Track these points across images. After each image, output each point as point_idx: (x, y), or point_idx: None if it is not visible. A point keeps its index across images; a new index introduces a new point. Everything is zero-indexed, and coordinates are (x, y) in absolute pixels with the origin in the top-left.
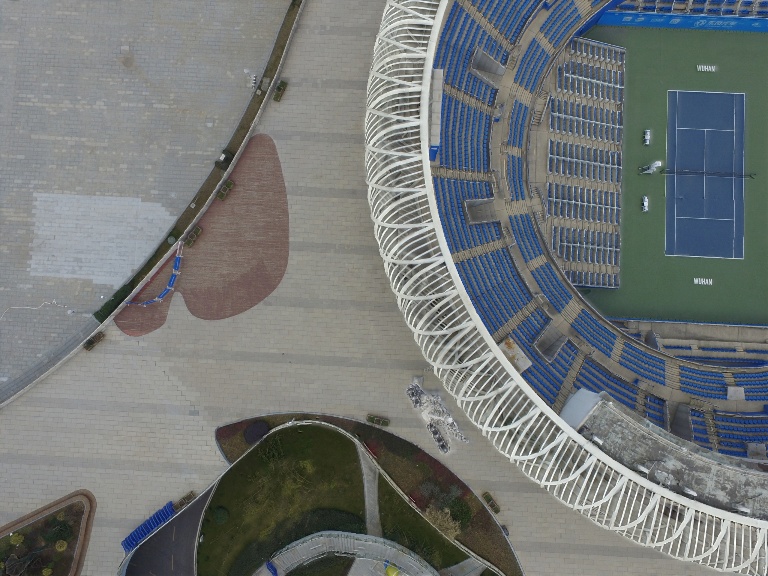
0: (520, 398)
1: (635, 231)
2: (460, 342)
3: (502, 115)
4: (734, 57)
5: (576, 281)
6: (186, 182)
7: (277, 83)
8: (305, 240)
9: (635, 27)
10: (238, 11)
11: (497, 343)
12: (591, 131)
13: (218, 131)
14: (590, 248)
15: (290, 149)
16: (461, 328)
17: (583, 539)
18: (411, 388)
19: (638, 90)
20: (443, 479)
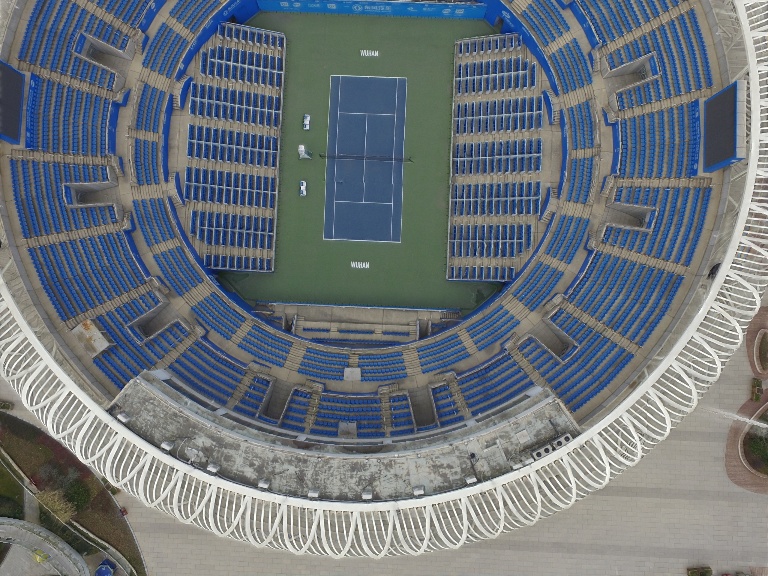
0: (50, 377)
1: (295, 215)
2: None
3: (130, 100)
4: (398, 42)
5: (219, 265)
6: None
7: None
8: None
9: (300, 12)
10: None
11: (77, 324)
12: (242, 116)
13: None
14: (237, 232)
15: None
16: None
17: None
18: None
19: (301, 75)
20: (64, 461)
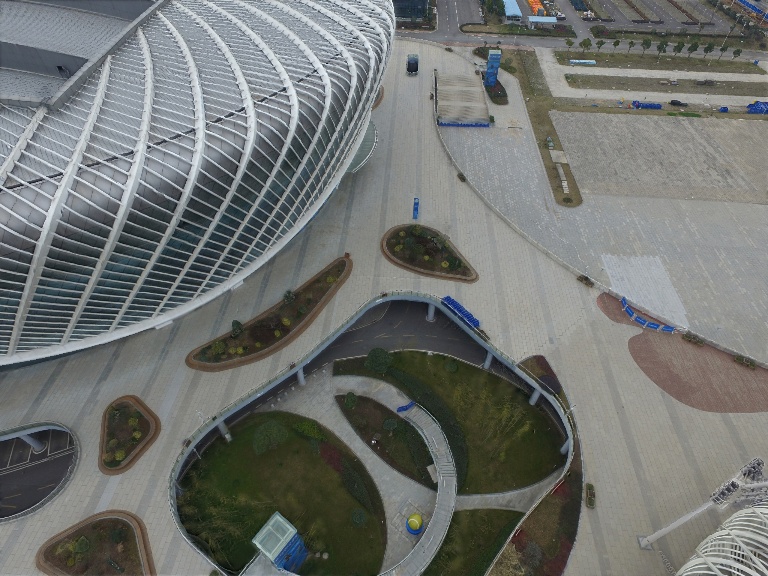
0: None
1: None
2: None
3: None
4: None
5: None
6: None
7: None
8: (737, 427)
9: None
10: None
11: None
12: None
13: None
14: None
15: None
16: None
17: None
18: None
19: None
20: (547, 572)
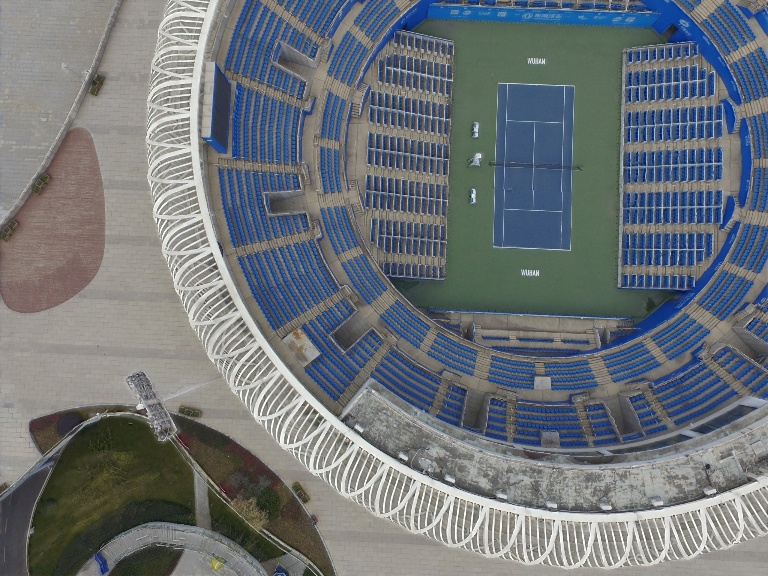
0: (284, 387)
1: (464, 223)
2: (226, 332)
3: (315, 108)
4: (565, 50)
5: (396, 273)
6: (19, 176)
7: (94, 77)
8: (121, 233)
9: (466, 20)
10: (74, 6)
11: (286, 333)
12: (415, 124)
13: (52, 126)
14: (413, 240)
15: (107, 143)
16: (227, 318)
17: (392, 528)
18: (131, 376)
19: (469, 83)
20: (254, 469)
